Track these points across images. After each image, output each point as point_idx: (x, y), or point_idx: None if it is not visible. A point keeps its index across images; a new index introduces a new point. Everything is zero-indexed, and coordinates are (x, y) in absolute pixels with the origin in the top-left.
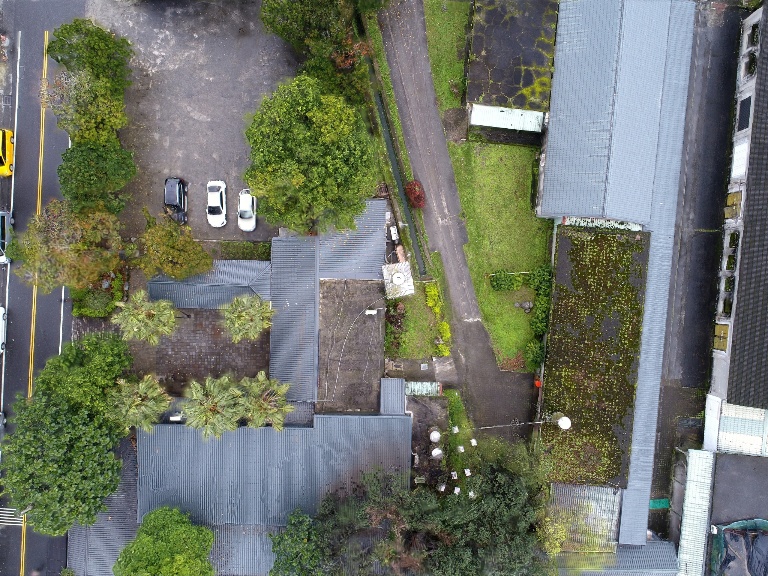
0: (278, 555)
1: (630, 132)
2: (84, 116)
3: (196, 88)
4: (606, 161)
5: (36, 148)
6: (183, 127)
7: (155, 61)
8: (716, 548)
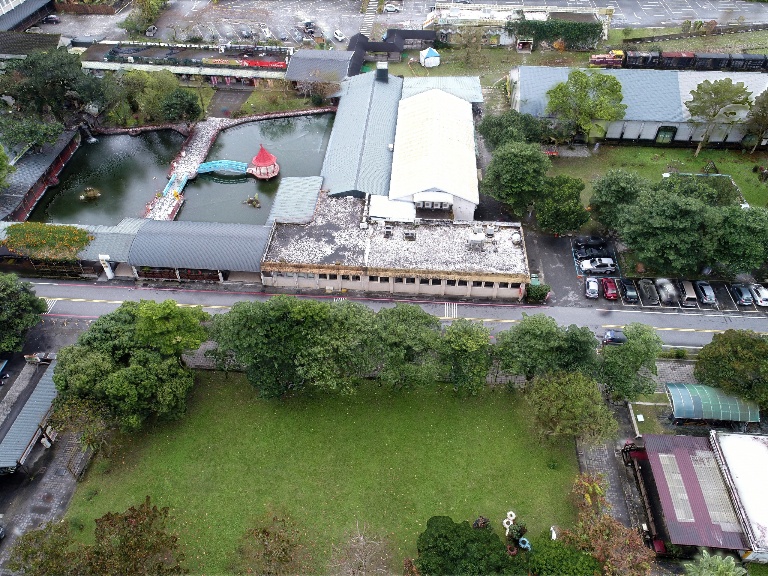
0: (14, 143)
1: None
2: None
3: None
4: None
5: None
6: None
7: None
8: (114, 59)
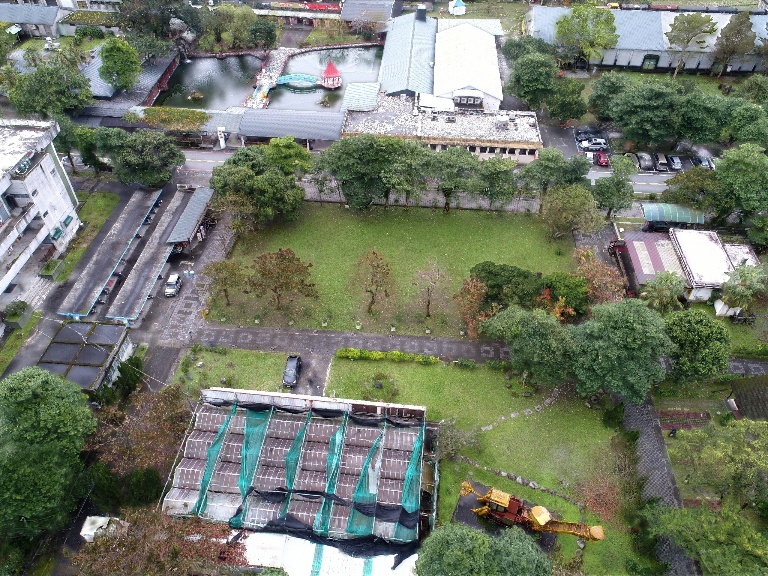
0: None
1: None
2: None
3: None
4: (40, 7)
5: None
6: None
7: None
8: (197, 2)
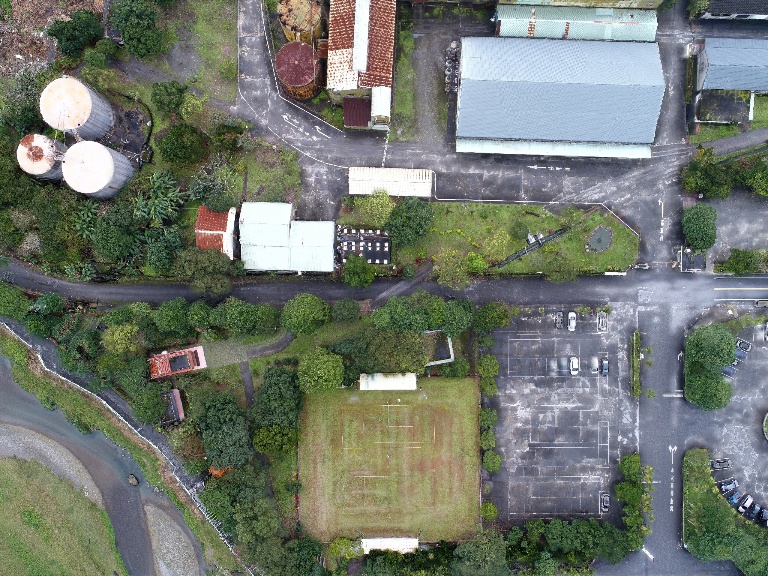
0: None
1: (763, 60)
2: (767, 260)
3: (735, 229)
4: None
5: (760, 291)
6: (750, 234)
7: (724, 246)
8: None
